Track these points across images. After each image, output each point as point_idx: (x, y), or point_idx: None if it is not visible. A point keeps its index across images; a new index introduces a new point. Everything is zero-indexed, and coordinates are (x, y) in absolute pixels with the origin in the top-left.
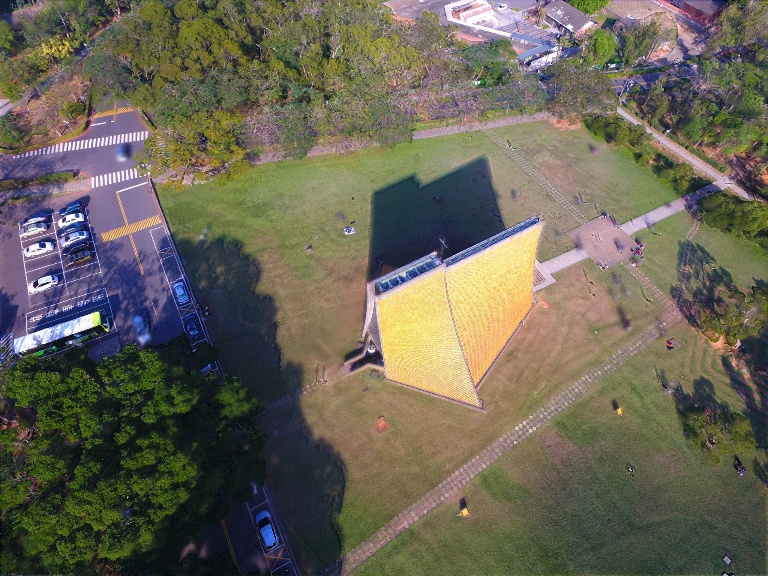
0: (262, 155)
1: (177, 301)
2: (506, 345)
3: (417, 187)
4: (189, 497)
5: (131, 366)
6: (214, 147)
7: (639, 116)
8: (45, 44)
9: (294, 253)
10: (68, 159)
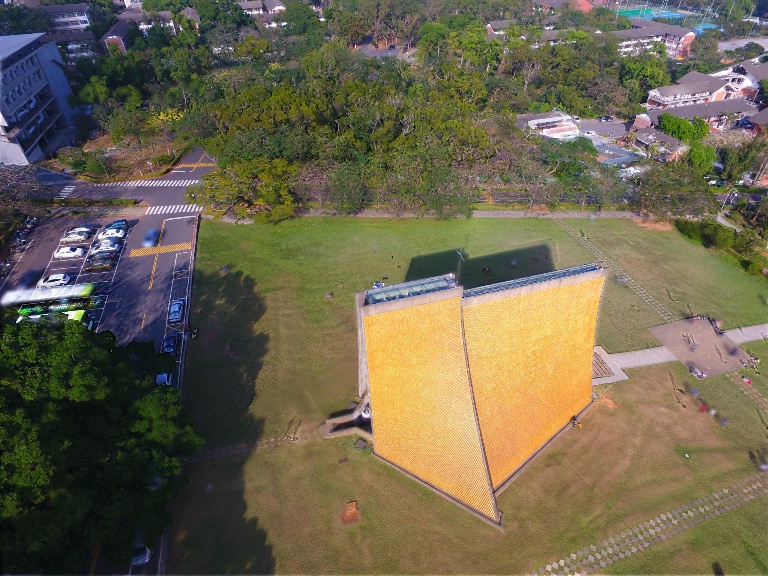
0: (312, 210)
1: (169, 318)
2: (548, 443)
3: (466, 257)
4: (27, 517)
5: (47, 332)
6: (263, 188)
7: (747, 228)
8: (163, 112)
9: (312, 297)
10: (138, 191)
